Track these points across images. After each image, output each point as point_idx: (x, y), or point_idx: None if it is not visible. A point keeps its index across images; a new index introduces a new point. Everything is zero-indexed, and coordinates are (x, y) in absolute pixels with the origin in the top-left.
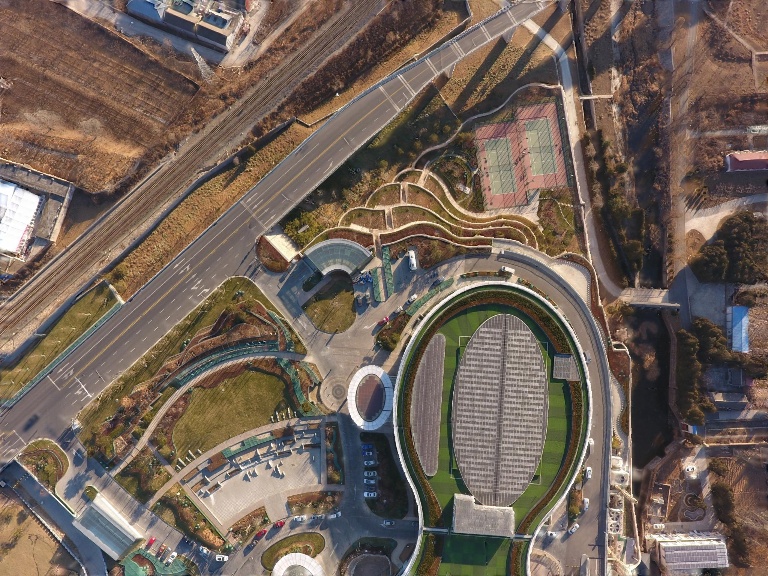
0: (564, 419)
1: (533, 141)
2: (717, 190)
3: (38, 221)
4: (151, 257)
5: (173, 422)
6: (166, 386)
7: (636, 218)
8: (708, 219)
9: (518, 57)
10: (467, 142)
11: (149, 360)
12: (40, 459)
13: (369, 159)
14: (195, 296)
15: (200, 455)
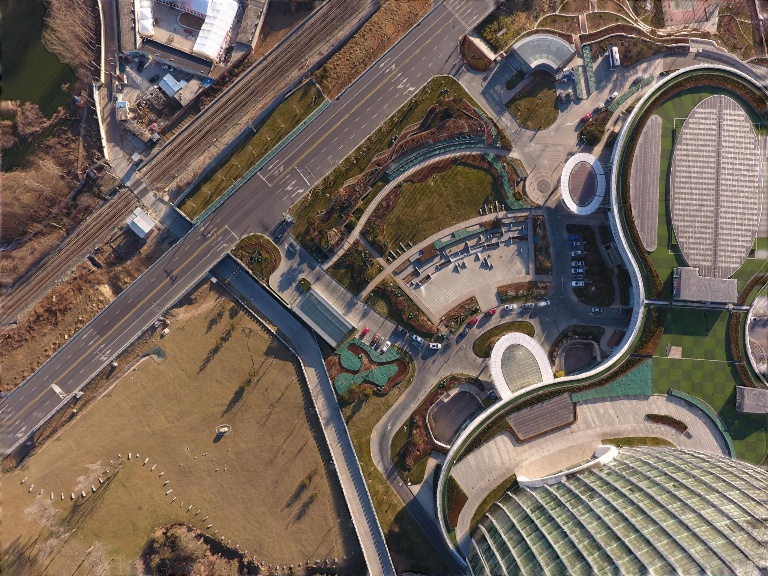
0: None
1: None
2: None
3: (235, 30)
4: (354, 59)
5: (384, 215)
6: (376, 180)
7: None
8: None
9: None
10: None
11: (358, 156)
12: (254, 252)
13: None
14: (401, 94)
15: (411, 247)
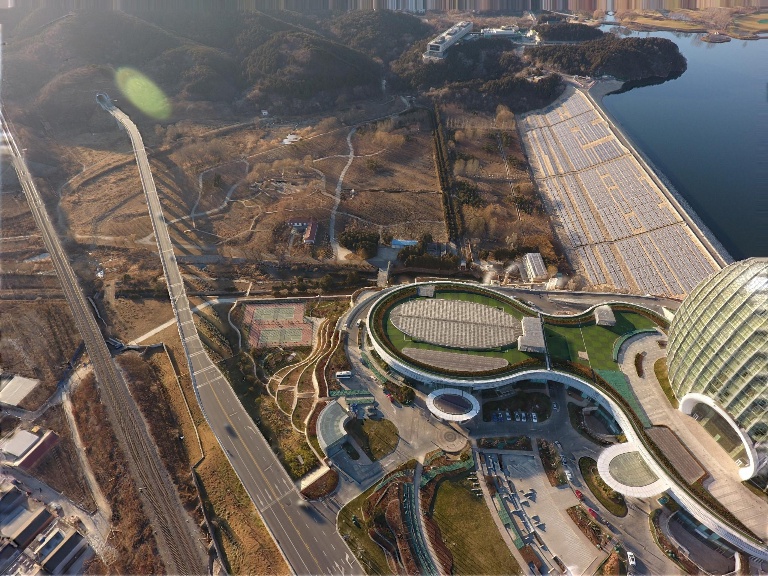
0: (459, 294)
1: (269, 317)
2: (324, 246)
3: None
4: None
5: None
6: None
7: (333, 277)
8: (340, 251)
9: (206, 321)
10: (257, 352)
11: None
12: None
13: (250, 412)
14: (352, 571)
15: None
